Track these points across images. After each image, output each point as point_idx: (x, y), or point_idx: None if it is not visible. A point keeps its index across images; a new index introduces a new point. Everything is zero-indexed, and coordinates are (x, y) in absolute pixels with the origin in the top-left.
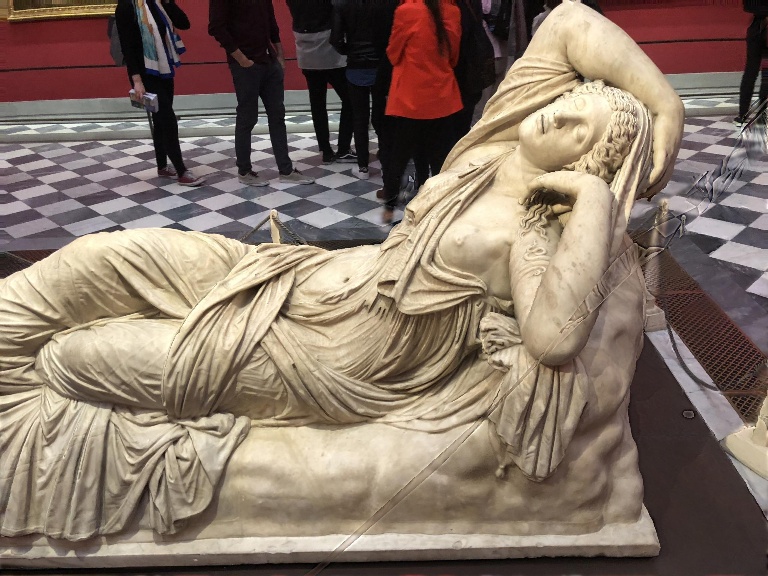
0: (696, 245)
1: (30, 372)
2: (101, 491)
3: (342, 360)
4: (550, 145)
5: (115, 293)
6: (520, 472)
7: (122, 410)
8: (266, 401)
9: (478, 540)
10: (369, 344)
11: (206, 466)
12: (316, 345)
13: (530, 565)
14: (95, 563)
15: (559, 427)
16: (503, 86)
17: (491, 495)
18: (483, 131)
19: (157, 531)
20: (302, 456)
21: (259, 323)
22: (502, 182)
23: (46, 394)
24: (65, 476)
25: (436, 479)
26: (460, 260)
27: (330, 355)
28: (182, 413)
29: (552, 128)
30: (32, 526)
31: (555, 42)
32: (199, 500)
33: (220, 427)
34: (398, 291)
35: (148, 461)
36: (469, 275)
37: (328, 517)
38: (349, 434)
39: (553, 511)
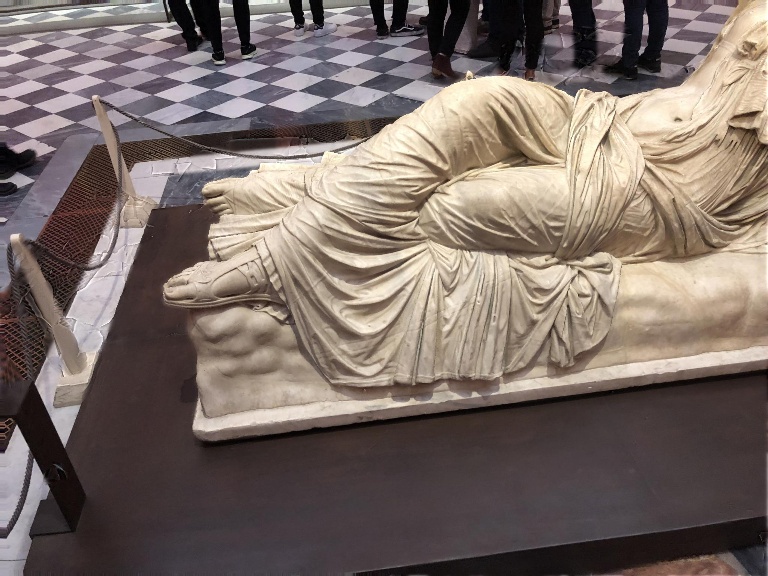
0: None
1: (417, 227)
2: (507, 333)
3: (697, 194)
4: None
5: (491, 141)
6: None
7: (517, 255)
8: (635, 238)
9: None
10: (719, 177)
11: (606, 300)
12: (676, 181)
13: None
14: (496, 401)
15: None
16: None
17: None
18: None
19: (560, 364)
20: (678, 285)
21: (635, 162)
22: None
23: (434, 247)
24: (479, 321)
25: None
26: None
27: (686, 190)
28: (574, 253)
29: None
30: (438, 373)
31: None
32: (596, 333)
33: (610, 264)
34: (763, 121)
35: (556, 300)
36: None
37: (704, 337)
38: (706, 263)
39: None
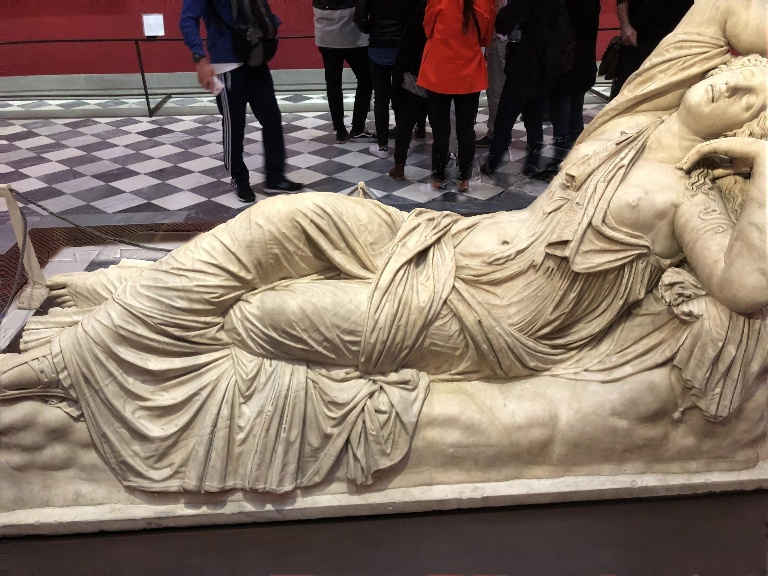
0: None
1: (220, 332)
2: (301, 445)
3: (514, 317)
4: (718, 113)
5: (301, 254)
6: (697, 414)
7: (317, 367)
8: (446, 357)
9: (651, 479)
10: (537, 302)
11: (404, 418)
12: (491, 303)
13: (696, 500)
14: (292, 515)
15: (744, 370)
16: (655, 59)
17: (666, 437)
18: (633, 101)
19: (356, 481)
20: (487, 407)
21: (443, 282)
22: (655, 149)
23: (237, 354)
24: (269, 431)
25: (617, 423)
26: (633, 221)
27: (503, 312)
28: (375, 368)
29: (722, 97)
30: (230, 482)
31: (716, 18)
32: (395, 451)
33: (412, 381)
34: (573, 250)
35: (350, 414)
36: (639, 235)
37: (513, 463)
38: (522, 386)
39: (720, 449)
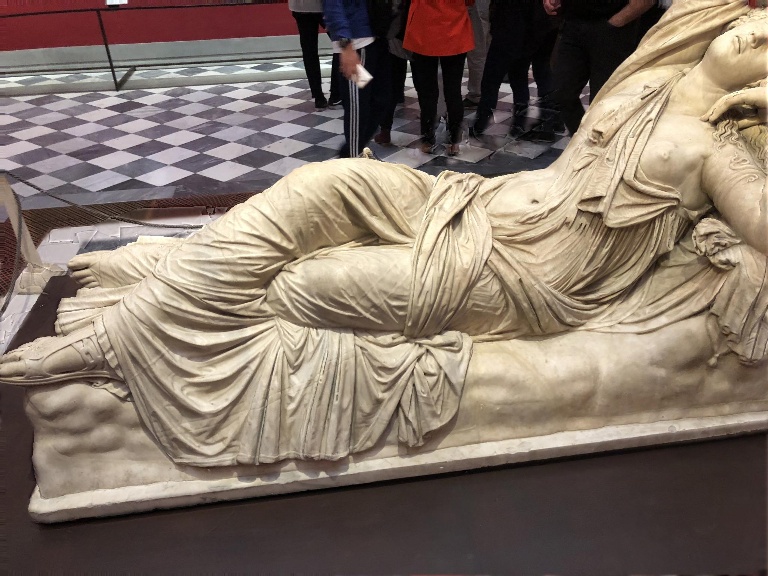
0: None
1: (264, 304)
2: (353, 412)
3: (549, 274)
4: (744, 64)
5: (340, 221)
6: (732, 358)
7: (364, 334)
8: (487, 317)
9: (688, 423)
10: (571, 258)
11: (452, 379)
12: (527, 262)
13: (728, 441)
14: (345, 481)
15: None
16: (676, 12)
17: (702, 382)
18: (655, 55)
19: (408, 444)
20: (529, 364)
21: (482, 243)
22: (679, 102)
23: (281, 325)
24: (322, 400)
25: (656, 372)
26: (664, 174)
27: (539, 270)
28: (421, 332)
29: (749, 48)
30: (283, 452)
31: None
32: (444, 412)
33: (458, 342)
34: (606, 206)
35: (401, 378)
36: (670, 188)
37: (557, 417)
38: (560, 342)
39: (752, 391)
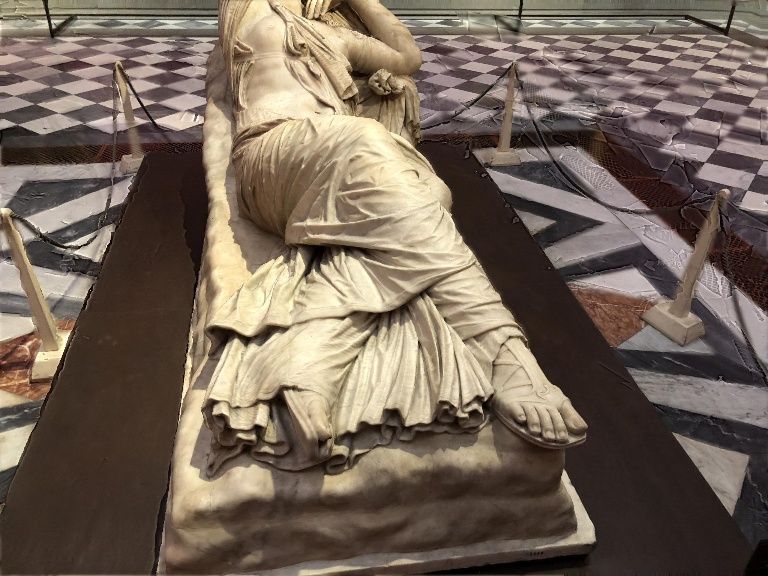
0: (16, 136)
1: None
2: None
3: None
4: None
5: None
6: None
7: None
8: None
9: None
10: None
11: None
12: None
13: None
14: None
15: None
16: None
17: None
18: None
19: None
20: None
21: None
22: None
23: None
24: None
25: None
26: (348, 55)
27: None
28: None
29: None
30: None
31: None
32: None
33: None
34: None
35: None
36: None
37: None
38: None
39: None
